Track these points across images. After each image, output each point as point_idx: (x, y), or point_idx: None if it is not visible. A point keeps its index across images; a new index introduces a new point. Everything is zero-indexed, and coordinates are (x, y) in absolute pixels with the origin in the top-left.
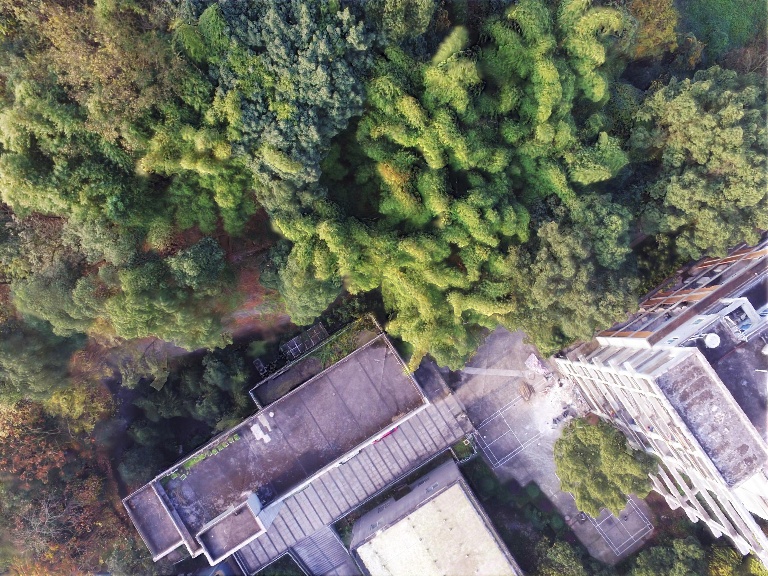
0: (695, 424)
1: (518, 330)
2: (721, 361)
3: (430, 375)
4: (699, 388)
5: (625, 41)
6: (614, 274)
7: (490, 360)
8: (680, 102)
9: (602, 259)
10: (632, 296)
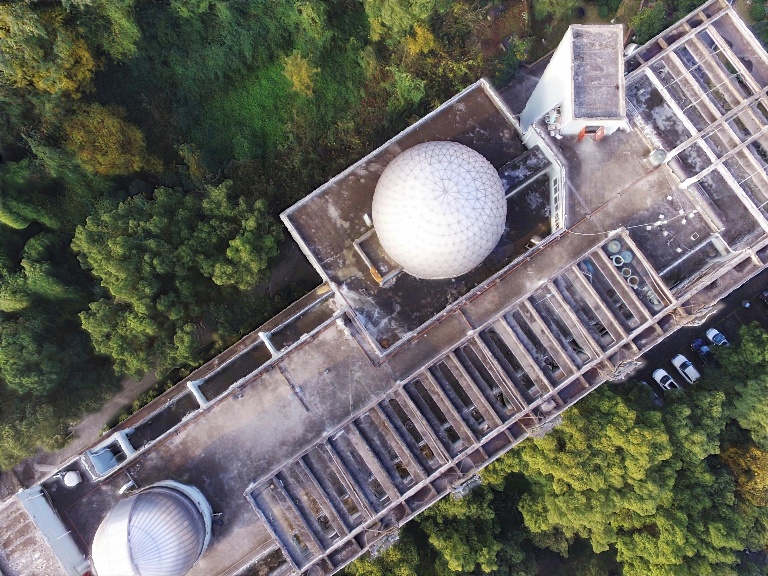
0: (17, 571)
1: (94, 426)
2: (86, 498)
3: (3, 473)
4: (24, 534)
5: (48, 169)
6: (41, 399)
7: (64, 457)
8: (76, 233)
9: (16, 387)
10: (38, 425)
